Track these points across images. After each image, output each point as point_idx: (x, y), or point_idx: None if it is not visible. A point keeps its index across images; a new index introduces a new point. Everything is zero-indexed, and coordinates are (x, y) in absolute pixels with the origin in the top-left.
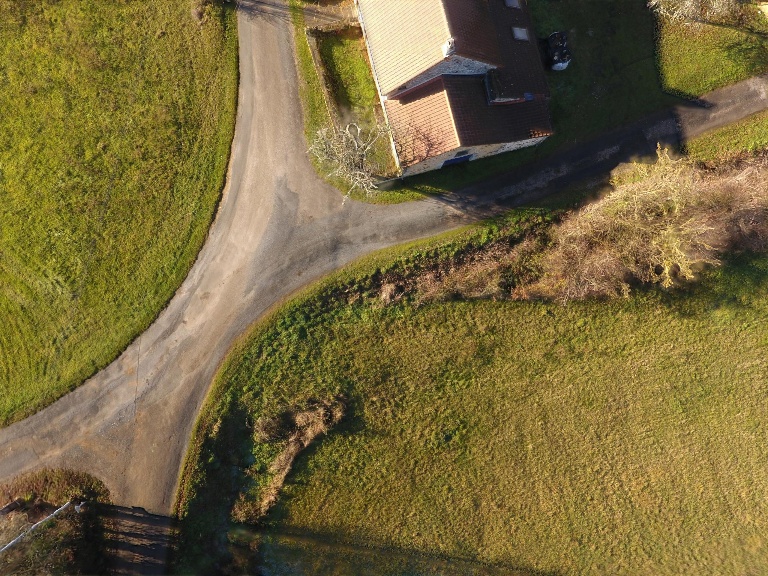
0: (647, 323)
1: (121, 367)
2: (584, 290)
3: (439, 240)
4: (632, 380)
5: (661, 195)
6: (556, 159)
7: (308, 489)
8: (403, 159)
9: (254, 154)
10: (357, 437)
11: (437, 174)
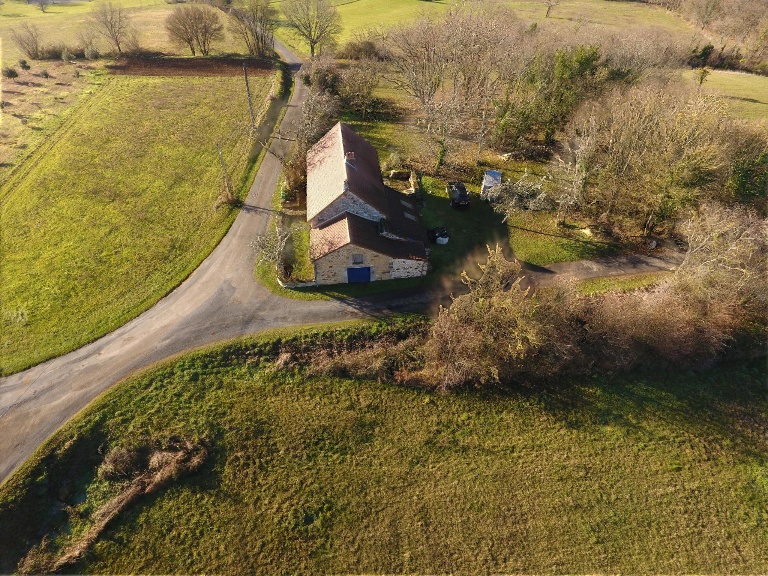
0: (534, 427)
1: (21, 378)
2: (458, 372)
3: (336, 326)
4: (526, 487)
5: (491, 269)
6: (437, 287)
7: (124, 553)
8: (313, 256)
9: (216, 266)
10: (206, 496)
11: (344, 286)
